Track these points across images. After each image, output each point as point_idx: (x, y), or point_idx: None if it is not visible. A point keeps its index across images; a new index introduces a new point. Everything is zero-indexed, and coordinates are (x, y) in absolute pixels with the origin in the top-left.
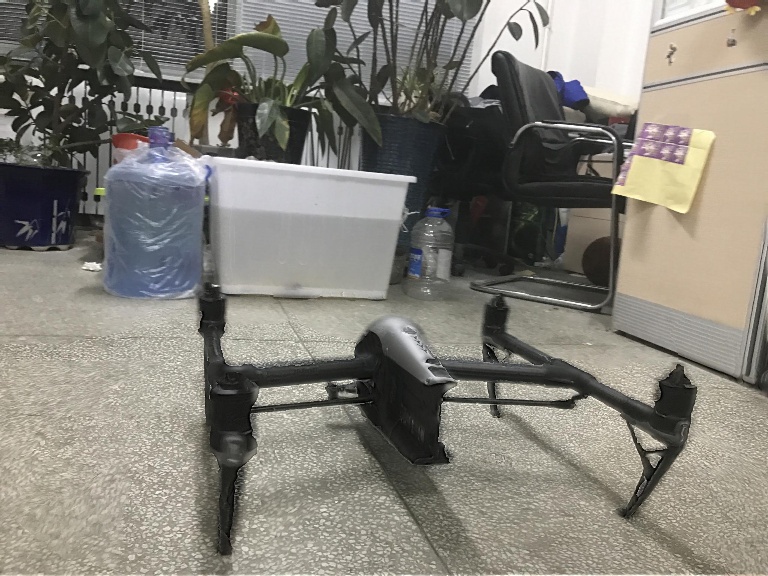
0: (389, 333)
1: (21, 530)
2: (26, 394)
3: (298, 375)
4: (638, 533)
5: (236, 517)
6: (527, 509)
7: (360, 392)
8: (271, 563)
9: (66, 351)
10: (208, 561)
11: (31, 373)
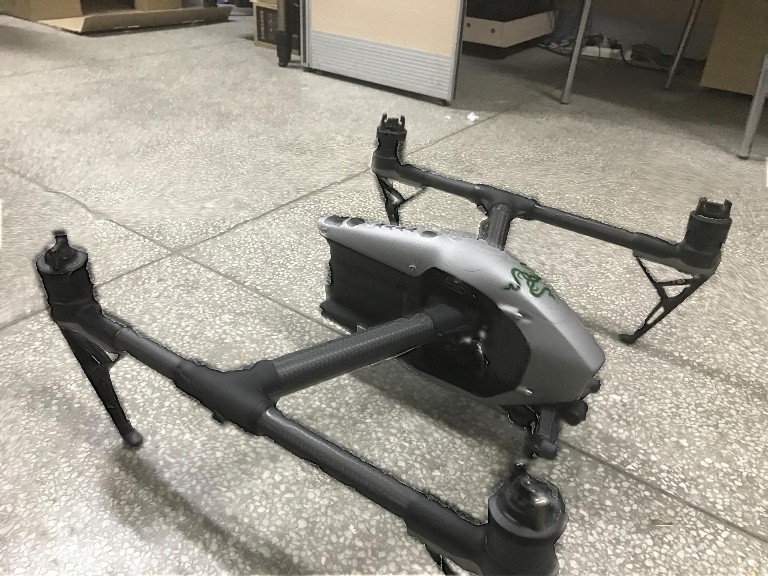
0: None
1: None
2: None
3: None
4: None
5: None
6: None
7: None
8: None
9: None
10: None
11: None
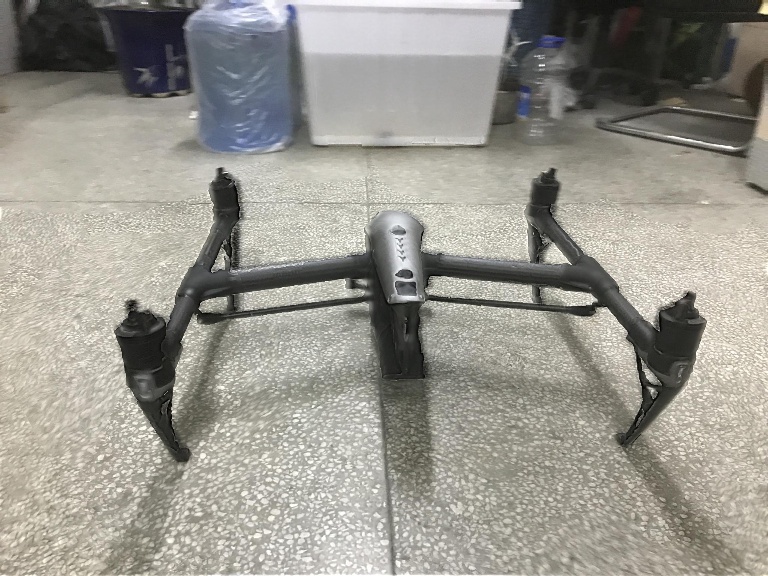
0: (379, 232)
1: (24, 422)
2: (82, 272)
3: (278, 279)
4: (629, 467)
5: (210, 419)
6: (512, 427)
7: None
8: (219, 474)
9: (136, 221)
10: (164, 467)
11: (95, 248)
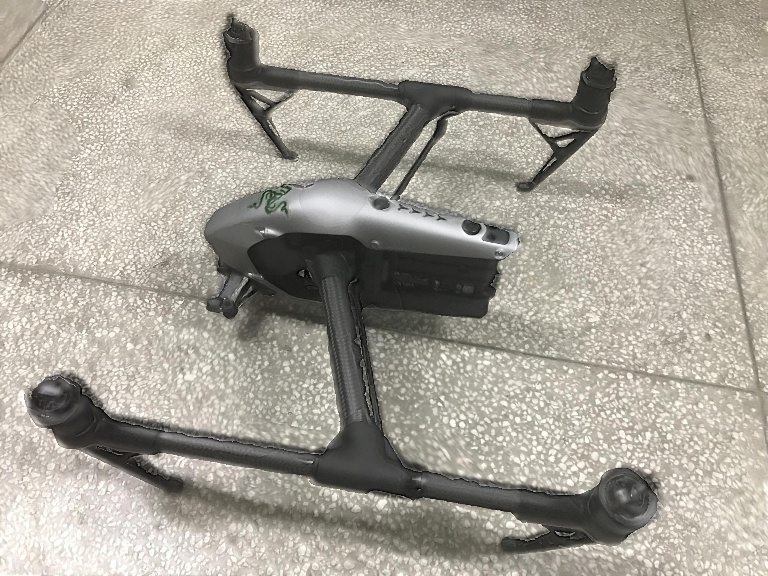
0: (357, 222)
1: None
2: None
3: None
4: (553, 198)
5: (446, 518)
6: None
7: (277, 284)
8: None
9: None
10: (526, 568)
11: None
